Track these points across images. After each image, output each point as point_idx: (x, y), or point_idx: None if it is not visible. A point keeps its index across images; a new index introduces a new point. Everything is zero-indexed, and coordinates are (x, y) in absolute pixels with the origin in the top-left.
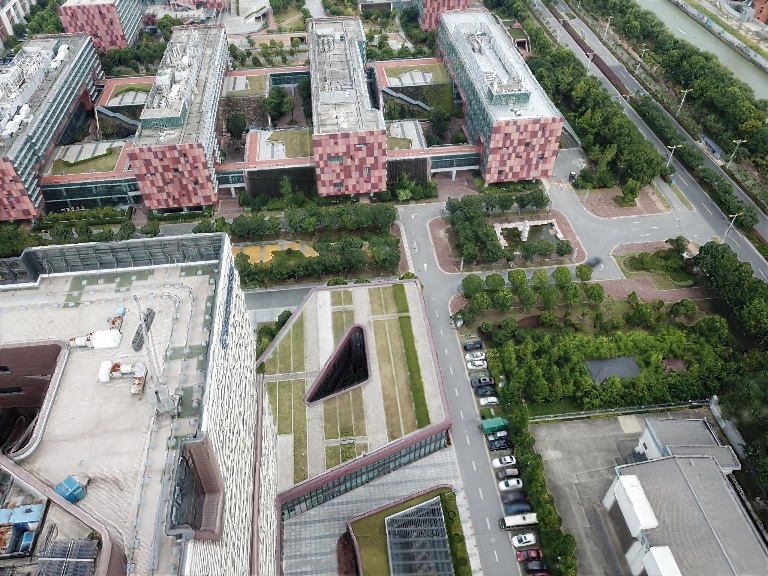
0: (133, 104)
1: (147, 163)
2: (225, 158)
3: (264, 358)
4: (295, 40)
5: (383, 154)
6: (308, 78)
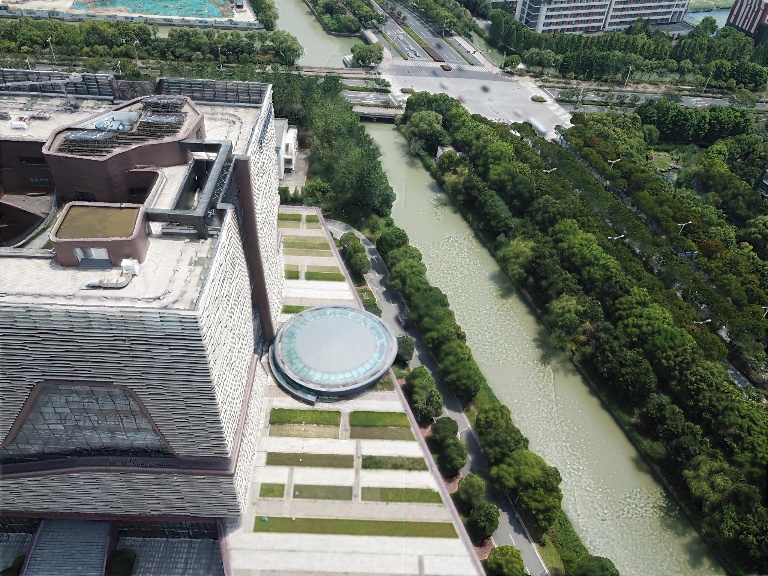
0: None
1: None
2: None
3: None
4: None
5: None
6: None
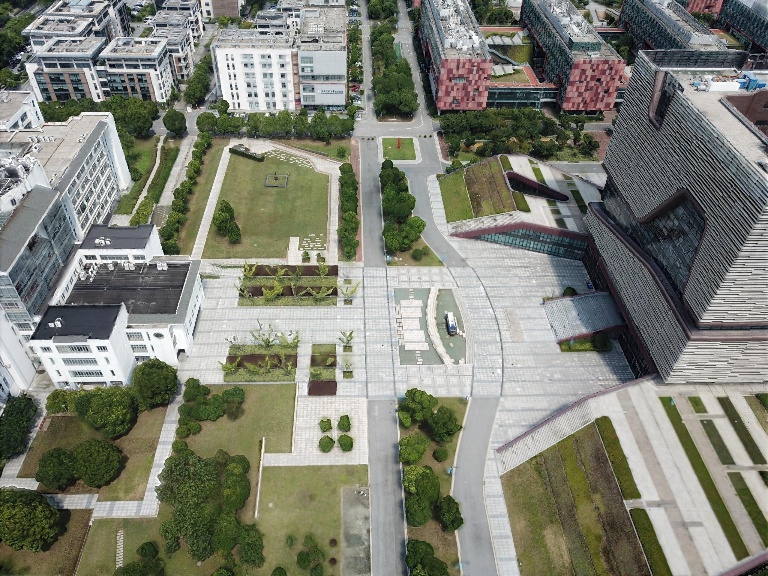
0: (505, 44)
1: (583, 72)
2: None
3: None
4: (587, 12)
5: None
6: (630, 36)
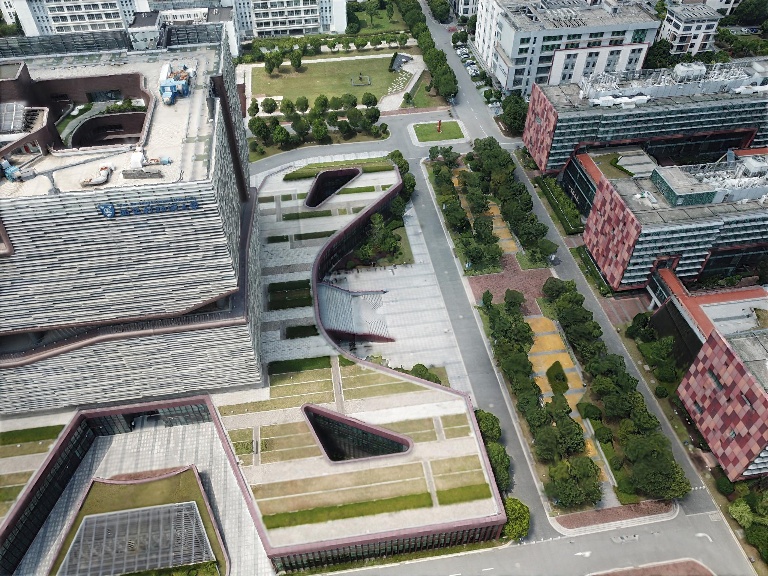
0: None
1: (604, 202)
2: (726, 286)
3: (361, 364)
4: None
5: (760, 442)
6: None
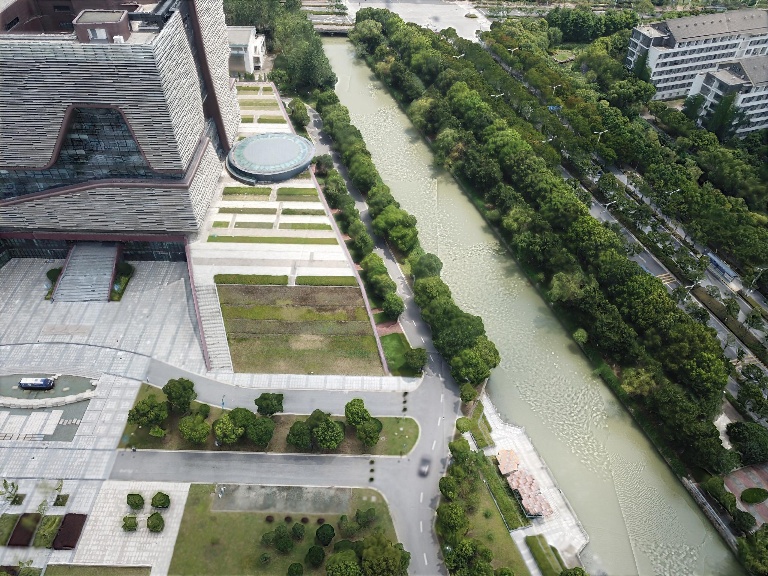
0: None
1: None
2: None
3: None
4: None
5: None
6: None
